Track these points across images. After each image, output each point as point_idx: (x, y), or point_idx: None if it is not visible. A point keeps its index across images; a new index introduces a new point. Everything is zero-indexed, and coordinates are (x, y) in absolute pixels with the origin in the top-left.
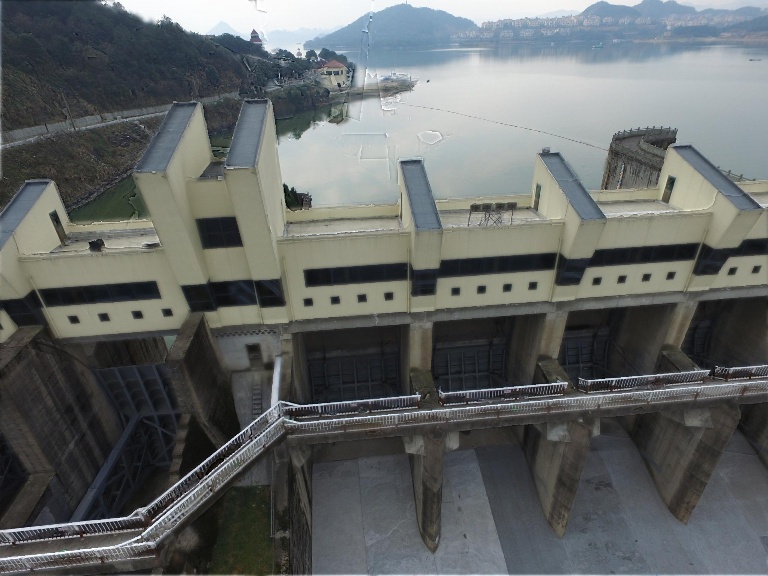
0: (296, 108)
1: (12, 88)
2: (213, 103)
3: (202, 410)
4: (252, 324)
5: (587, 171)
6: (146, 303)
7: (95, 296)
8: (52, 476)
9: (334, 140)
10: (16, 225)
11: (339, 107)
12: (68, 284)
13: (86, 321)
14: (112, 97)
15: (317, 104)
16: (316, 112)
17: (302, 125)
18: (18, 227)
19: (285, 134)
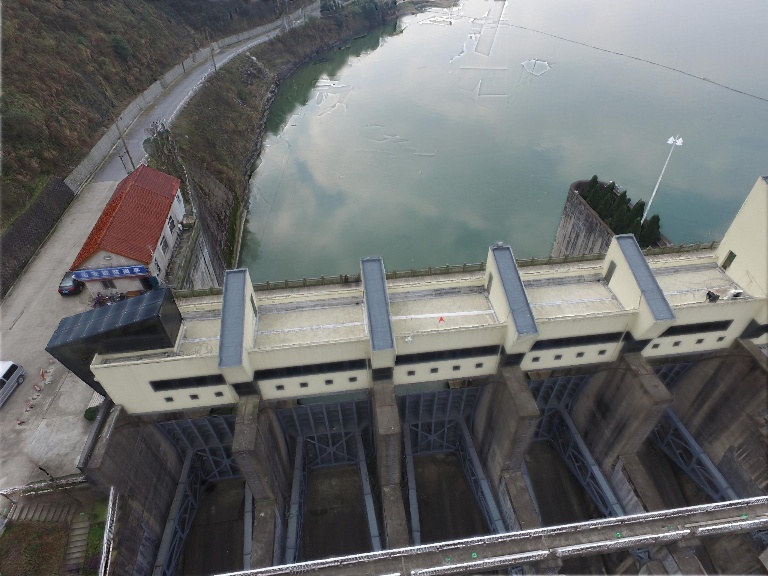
0: (370, 24)
1: (148, 24)
2: (302, 24)
3: (767, 413)
4: (764, 343)
5: (742, 122)
6: (713, 333)
7: (682, 330)
8: (636, 457)
9: (449, 73)
10: (654, 283)
11: (404, 20)
12: (675, 324)
13: (662, 347)
14: (214, 23)
15: (386, 18)
16: (385, 27)
17: (374, 43)
18: (658, 285)
19: None
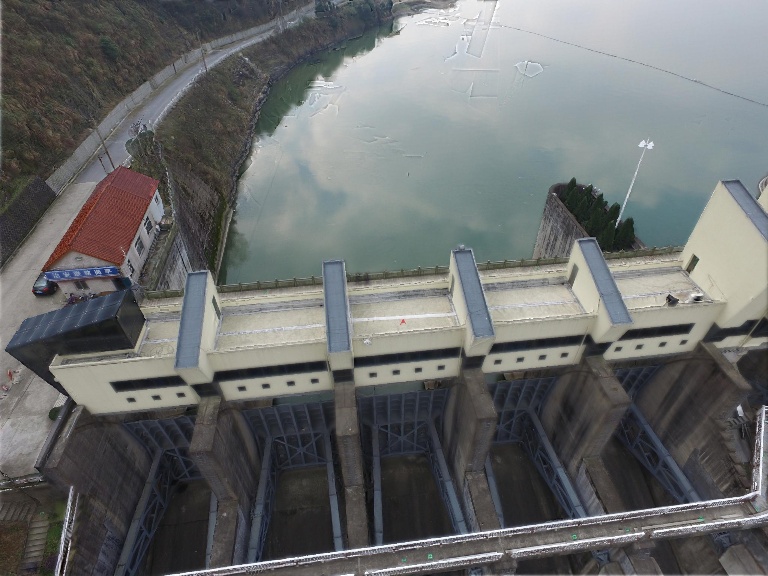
0: (365, 25)
1: (139, 24)
2: (296, 25)
3: None
4: None
5: (731, 125)
6: (675, 337)
7: (644, 333)
8: (600, 459)
9: (442, 75)
10: (613, 286)
11: (400, 21)
12: (636, 327)
13: (625, 350)
14: (207, 23)
15: (382, 19)
16: (381, 28)
17: (370, 44)
18: None
19: (353, 55)
